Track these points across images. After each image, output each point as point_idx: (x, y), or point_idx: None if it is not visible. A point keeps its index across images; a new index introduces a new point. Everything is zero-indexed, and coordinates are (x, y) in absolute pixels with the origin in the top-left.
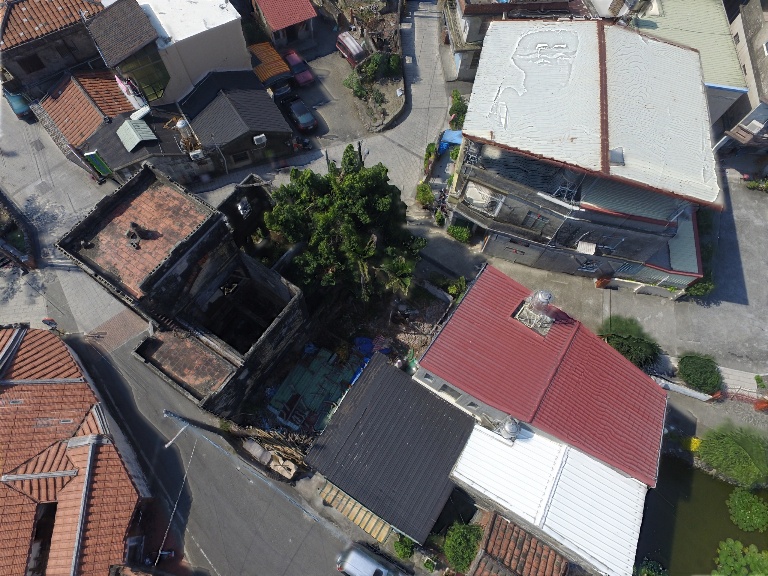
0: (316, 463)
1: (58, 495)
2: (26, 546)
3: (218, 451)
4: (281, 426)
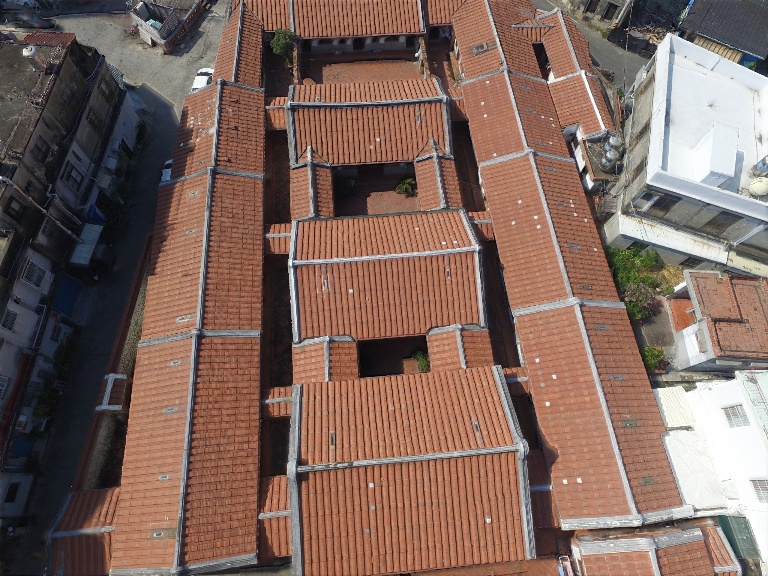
0: (688, 28)
1: (543, 38)
2: (535, 58)
3: (605, 45)
4: (652, 21)
